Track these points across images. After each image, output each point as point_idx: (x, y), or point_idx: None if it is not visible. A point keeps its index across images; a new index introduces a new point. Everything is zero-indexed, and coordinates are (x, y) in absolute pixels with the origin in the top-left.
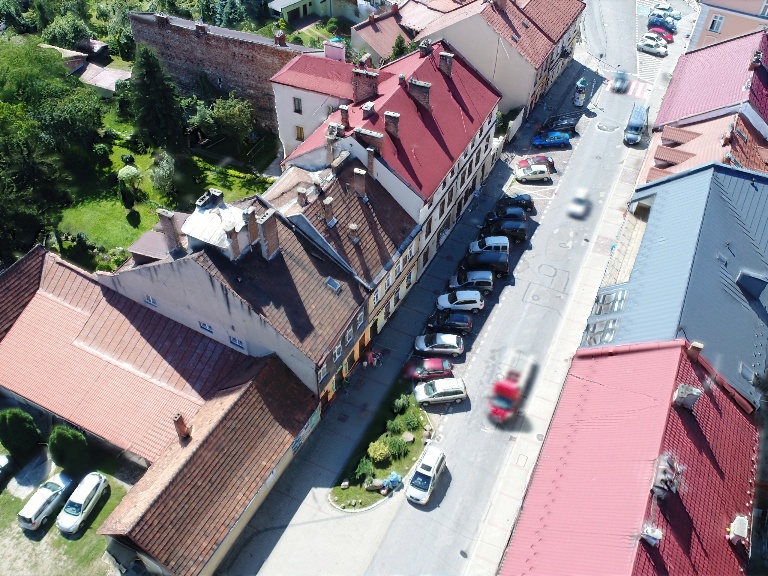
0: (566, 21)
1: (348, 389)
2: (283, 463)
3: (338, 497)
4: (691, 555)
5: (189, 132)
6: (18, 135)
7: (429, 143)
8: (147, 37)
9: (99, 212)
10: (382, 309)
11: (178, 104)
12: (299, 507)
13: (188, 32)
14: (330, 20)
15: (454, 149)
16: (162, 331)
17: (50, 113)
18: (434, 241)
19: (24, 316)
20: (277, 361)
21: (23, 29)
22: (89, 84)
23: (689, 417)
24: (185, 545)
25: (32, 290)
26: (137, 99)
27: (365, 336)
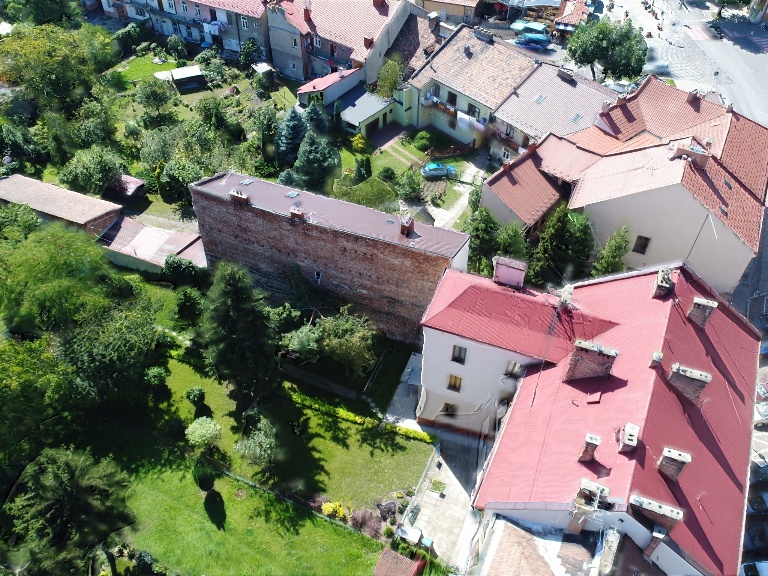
0: (764, 165)
1: None
2: None
3: None
4: None
5: (280, 355)
6: (46, 399)
7: (709, 468)
8: (215, 216)
9: (163, 494)
10: None
11: (271, 330)
12: None
13: (278, 218)
14: (420, 135)
15: (737, 465)
16: None
17: (89, 351)
18: None
19: None
20: None
21: (32, 156)
22: (127, 255)
23: None
24: None
25: None
26: (215, 331)
27: None
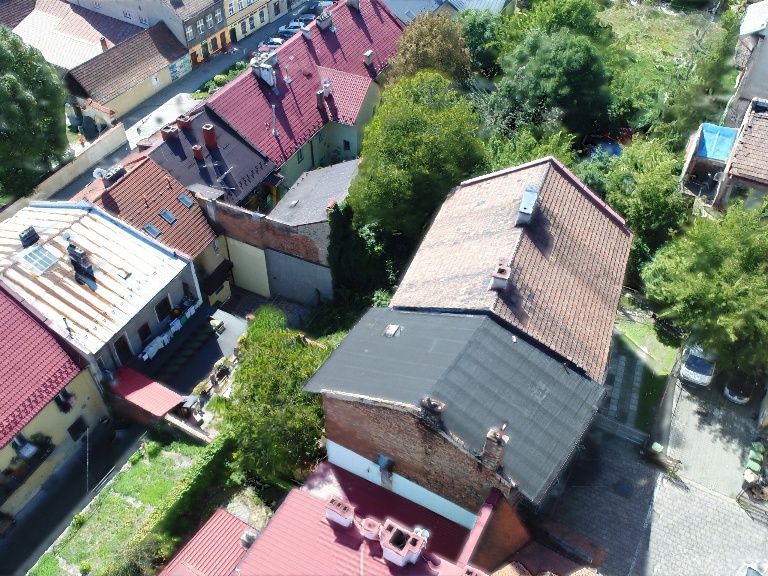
0: None
1: (212, 60)
2: (165, 80)
3: (193, 96)
4: (335, 55)
5: None
6: None
7: None
8: None
9: None
10: (239, 23)
11: None
12: (171, 99)
13: None
14: None
15: None
16: (104, 23)
17: None
18: (284, 1)
19: (25, 21)
20: (164, 25)
21: None
22: None
23: (357, 13)
24: (101, 88)
25: (30, 9)
26: None
27: (226, 35)
